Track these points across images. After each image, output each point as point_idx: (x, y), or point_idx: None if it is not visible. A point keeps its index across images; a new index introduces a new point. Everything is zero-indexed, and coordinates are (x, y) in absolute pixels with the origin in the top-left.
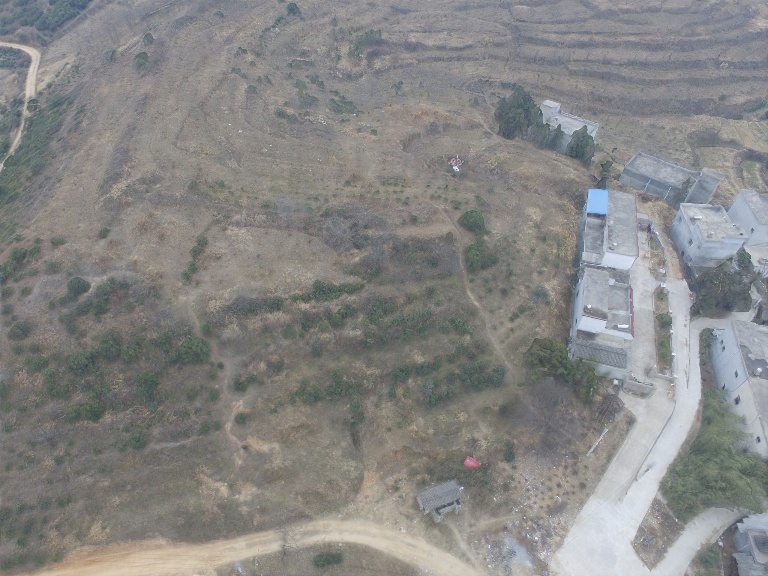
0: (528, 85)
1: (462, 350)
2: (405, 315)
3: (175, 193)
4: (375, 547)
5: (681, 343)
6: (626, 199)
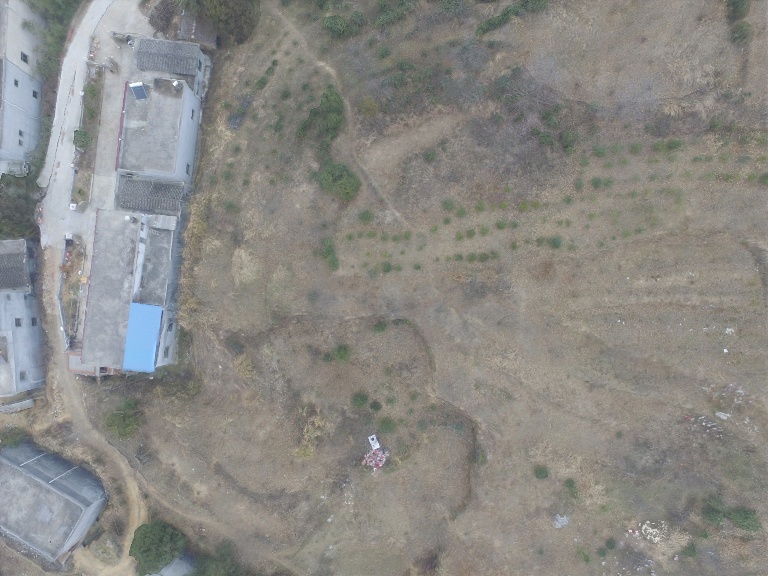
0: None
1: (334, 1)
2: (413, 7)
3: None
4: None
5: (70, 135)
6: (97, 350)
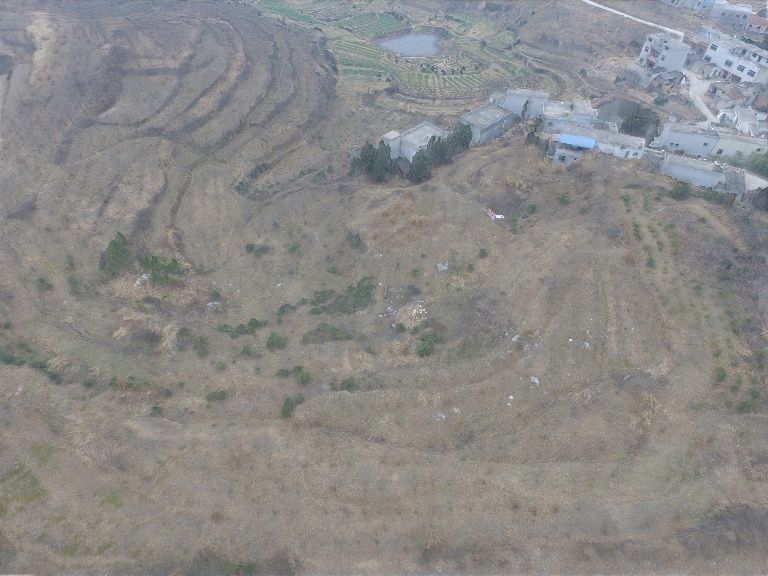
0: (264, 158)
1: None
2: None
3: None
4: None
5: None
6: (571, 129)
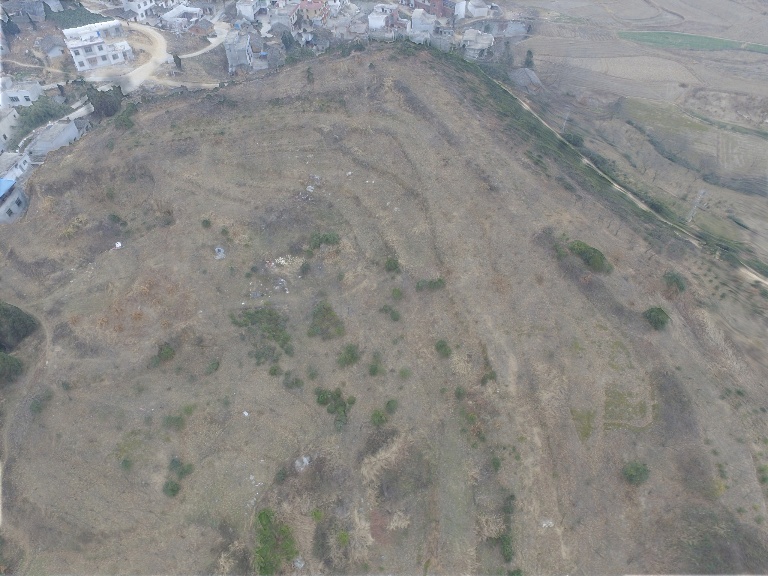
0: None
1: None
2: None
3: (345, 88)
4: (208, 84)
5: None
6: None
